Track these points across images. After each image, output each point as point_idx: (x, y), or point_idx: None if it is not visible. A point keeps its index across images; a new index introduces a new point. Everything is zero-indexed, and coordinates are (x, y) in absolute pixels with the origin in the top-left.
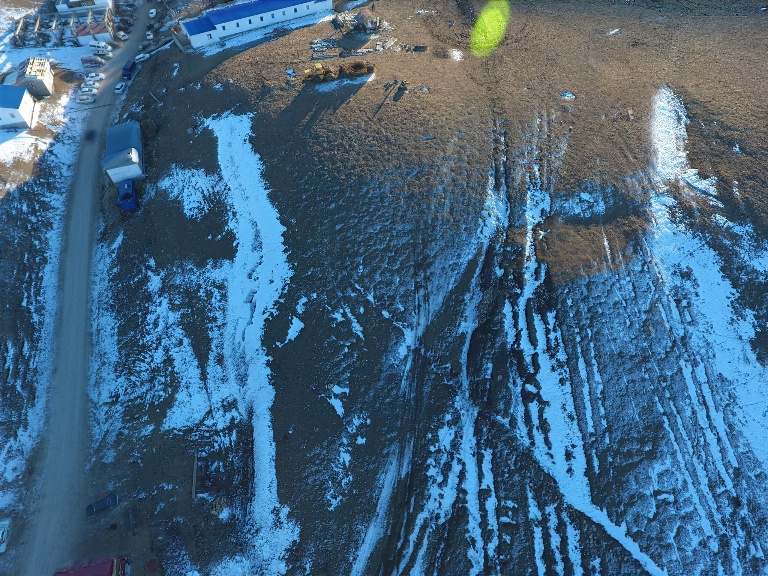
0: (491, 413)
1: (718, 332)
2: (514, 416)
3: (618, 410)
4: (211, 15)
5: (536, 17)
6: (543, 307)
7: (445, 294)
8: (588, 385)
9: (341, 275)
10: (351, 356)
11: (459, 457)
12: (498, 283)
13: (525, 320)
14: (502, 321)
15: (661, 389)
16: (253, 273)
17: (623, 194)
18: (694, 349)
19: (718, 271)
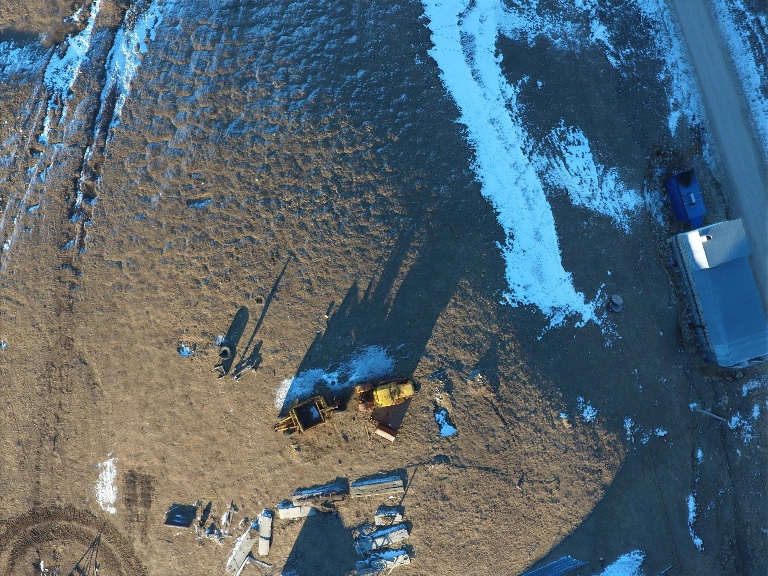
0: None
1: None
2: None
3: None
4: None
5: None
6: None
7: None
8: None
9: None
10: None
11: None
12: None
13: None
14: None
15: None
16: (469, 4)
17: None
18: None
19: None
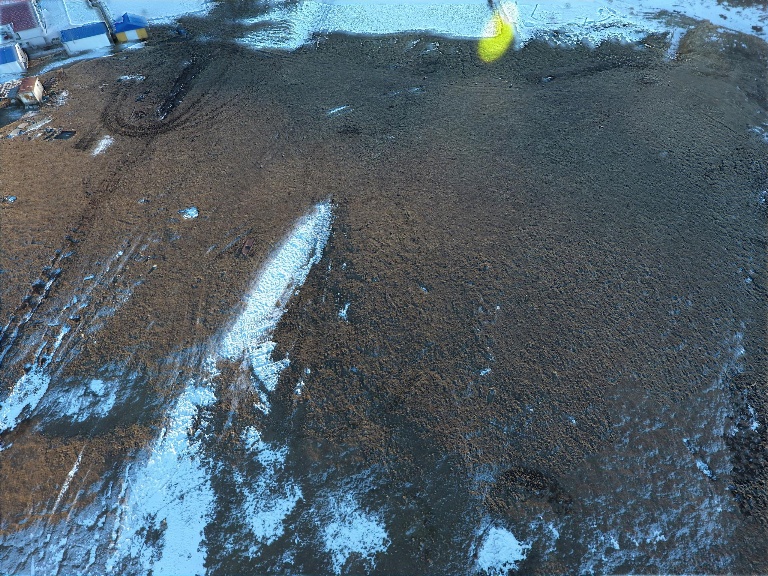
0: None
1: None
2: None
3: None
4: None
5: (259, 87)
6: None
7: None
8: None
9: None
10: None
11: None
12: None
13: None
14: None
15: None
16: None
17: (147, 384)
18: None
19: (200, 532)
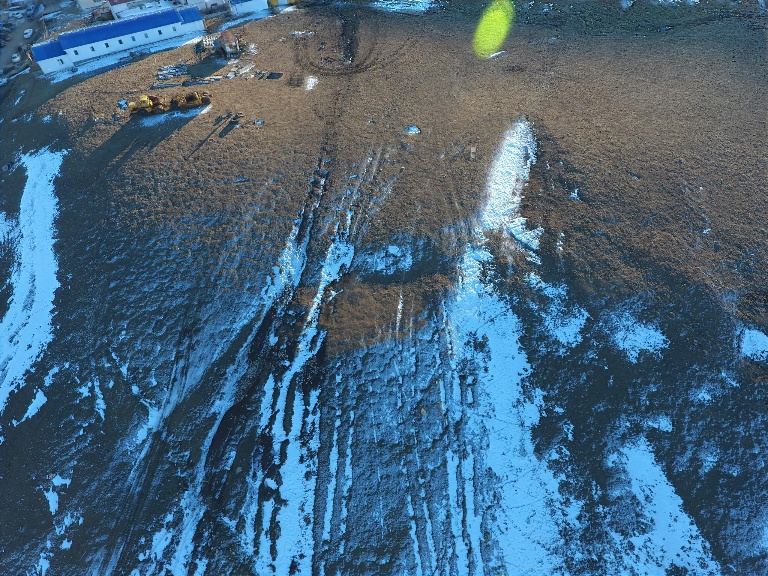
0: (218, 513)
1: (499, 416)
2: (243, 518)
3: (362, 512)
4: (62, 39)
5: (418, 38)
6: (308, 384)
7: (207, 366)
8: (335, 480)
9: (100, 342)
10: (84, 440)
11: (168, 568)
12: (268, 354)
13: (285, 399)
14: (259, 400)
15: (417, 487)
16: (15, 336)
17: (435, 247)
18: (467, 437)
19: (516, 342)
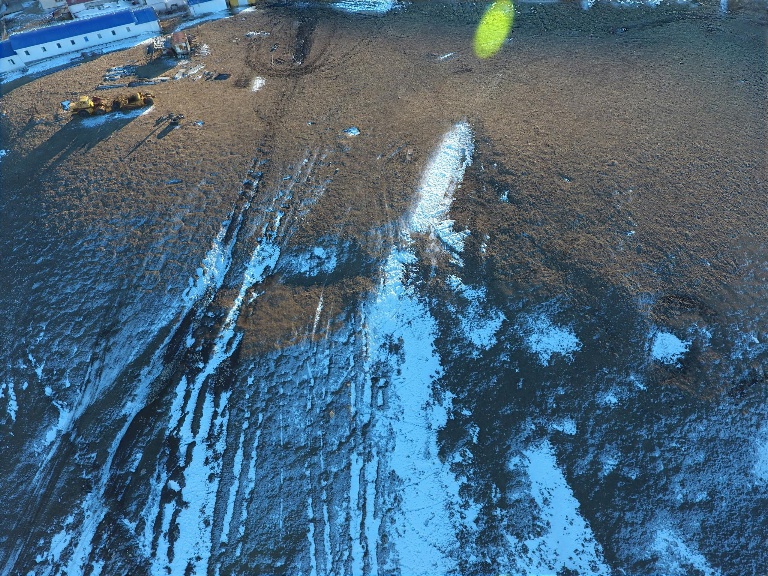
0: (119, 515)
1: (407, 419)
2: (144, 520)
3: (262, 515)
4: (13, 39)
5: (372, 39)
6: (219, 386)
7: (121, 368)
8: (238, 483)
9: (18, 343)
10: None
11: (64, 570)
12: (183, 355)
13: (195, 401)
14: (170, 402)
15: (318, 489)
16: None
17: (360, 249)
18: (373, 440)
19: (431, 344)
